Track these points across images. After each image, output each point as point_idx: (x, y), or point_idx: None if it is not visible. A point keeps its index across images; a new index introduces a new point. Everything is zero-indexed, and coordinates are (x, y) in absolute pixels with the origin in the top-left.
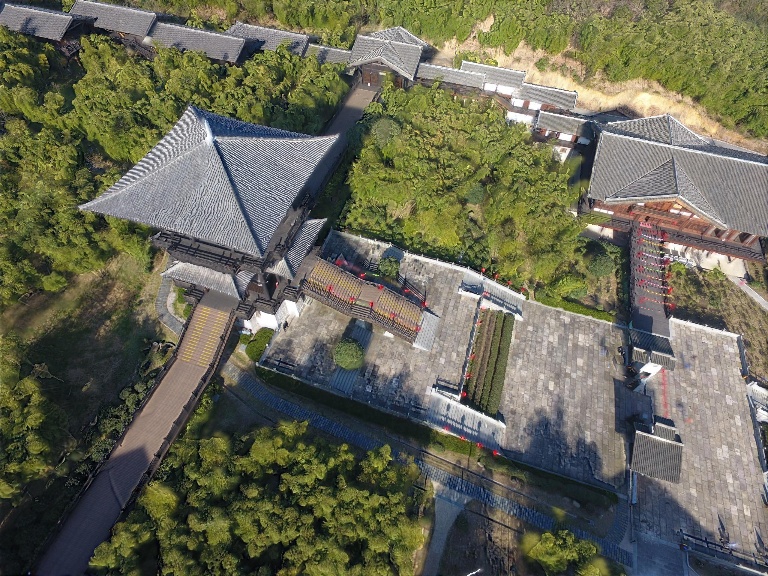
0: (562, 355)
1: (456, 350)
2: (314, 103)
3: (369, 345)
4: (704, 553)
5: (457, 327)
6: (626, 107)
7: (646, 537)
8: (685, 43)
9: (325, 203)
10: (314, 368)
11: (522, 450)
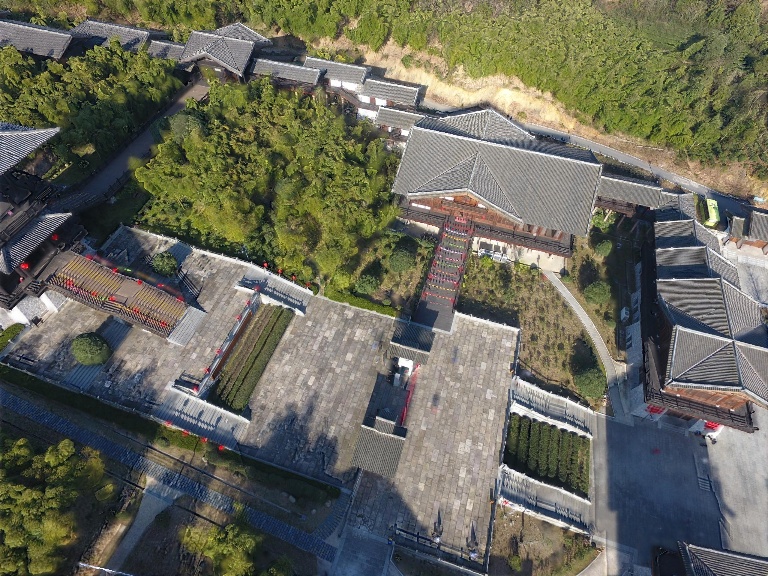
0: (333, 350)
1: (212, 345)
2: (126, 99)
3: (123, 340)
4: (407, 547)
5: (221, 322)
6: (488, 103)
7: (357, 532)
8: (538, 39)
9: (126, 199)
10: (54, 364)
11: (259, 445)
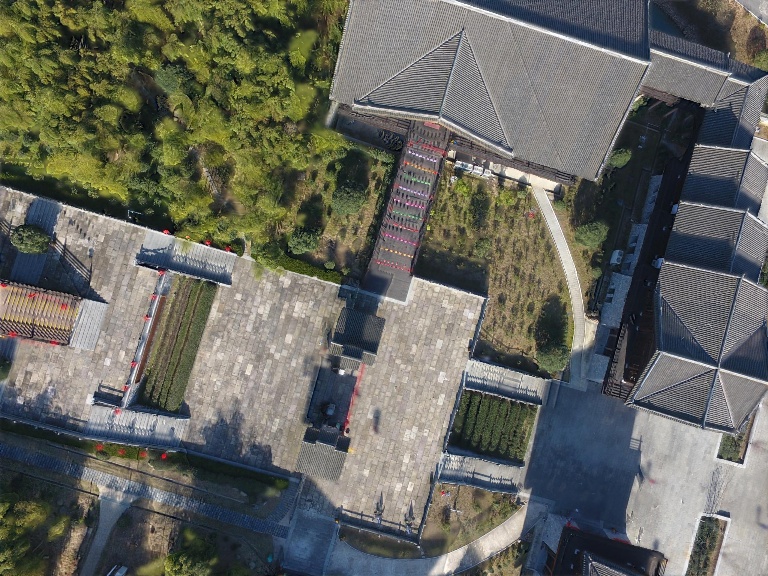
0: (269, 331)
1: (125, 347)
2: None
3: (18, 346)
4: None
5: (129, 316)
6: None
7: (307, 514)
8: None
9: None
10: None
11: (203, 442)
